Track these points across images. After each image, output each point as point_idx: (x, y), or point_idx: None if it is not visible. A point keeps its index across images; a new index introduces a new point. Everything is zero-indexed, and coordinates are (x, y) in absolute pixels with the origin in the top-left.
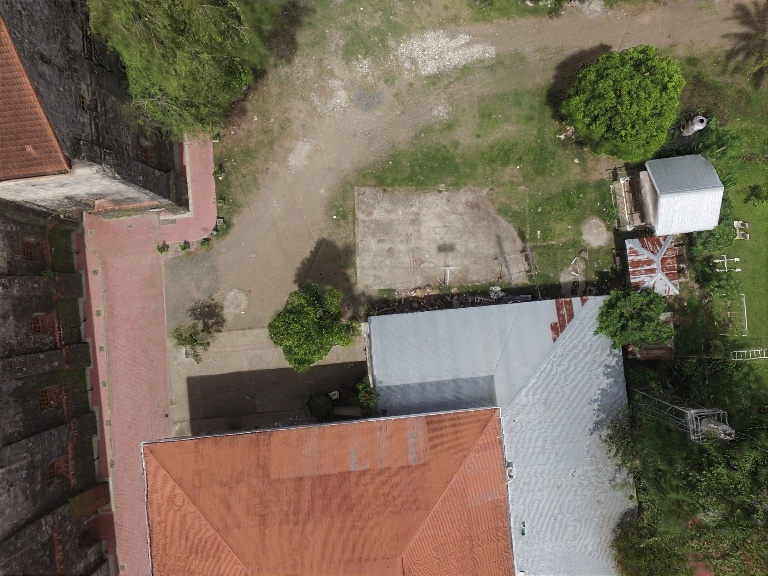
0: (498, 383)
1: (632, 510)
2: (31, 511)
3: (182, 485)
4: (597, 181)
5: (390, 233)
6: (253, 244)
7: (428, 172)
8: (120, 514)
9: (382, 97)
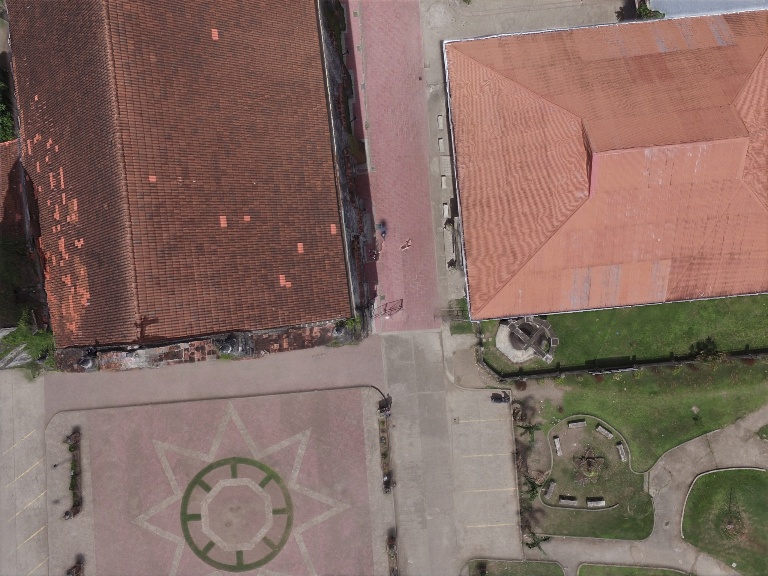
0: None
1: None
2: None
3: (494, 69)
4: None
5: None
6: None
7: None
8: (375, 175)
9: None
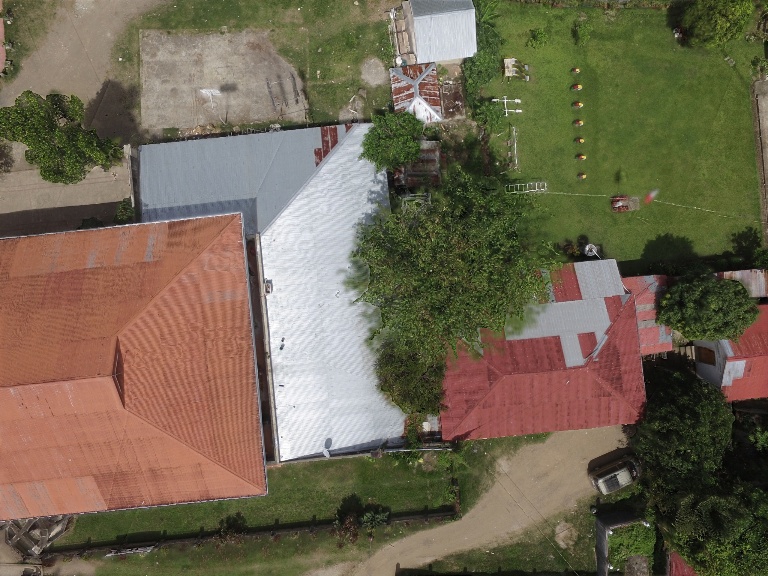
0: (260, 204)
1: None
2: None
3: None
4: (376, 22)
5: (173, 74)
6: (41, 86)
7: (211, 15)
8: None
9: None
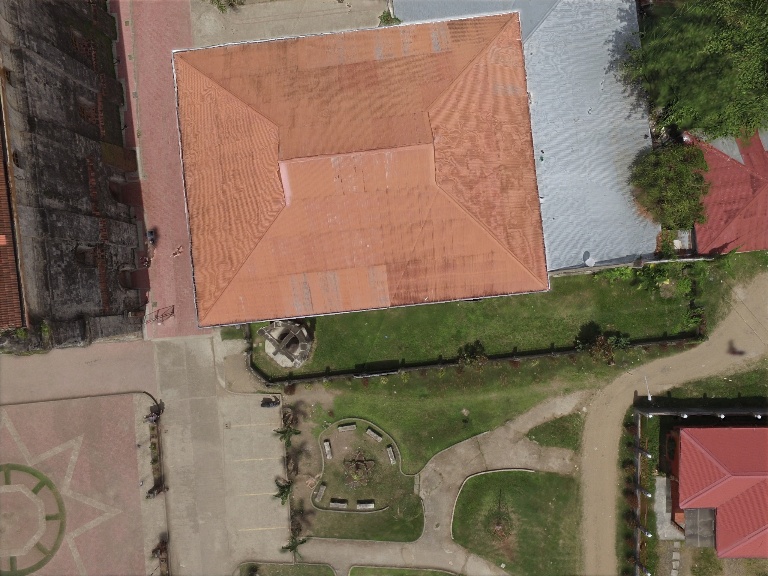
0: None
1: (647, 148)
2: (65, 122)
3: (212, 78)
4: None
5: None
6: None
7: None
8: (147, 182)
9: None
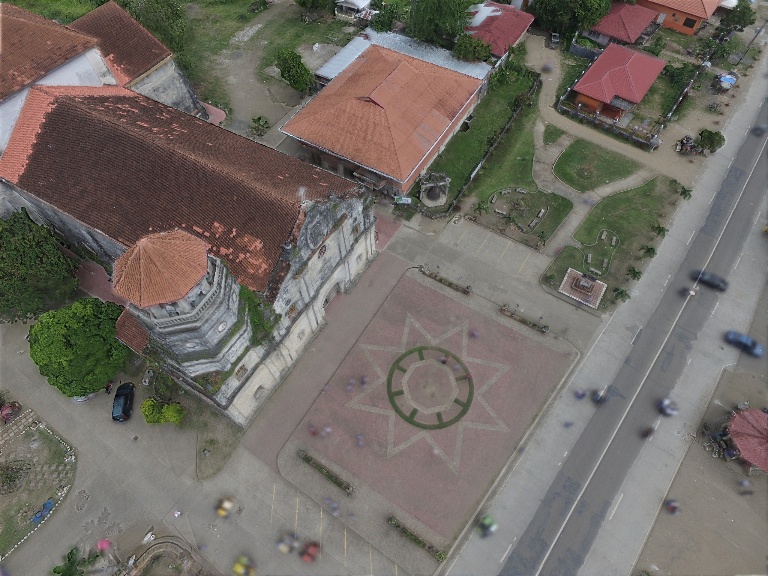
0: None
1: None
2: None
3: (307, 117)
4: None
5: None
6: (245, 107)
7: None
8: None
9: (240, 53)
